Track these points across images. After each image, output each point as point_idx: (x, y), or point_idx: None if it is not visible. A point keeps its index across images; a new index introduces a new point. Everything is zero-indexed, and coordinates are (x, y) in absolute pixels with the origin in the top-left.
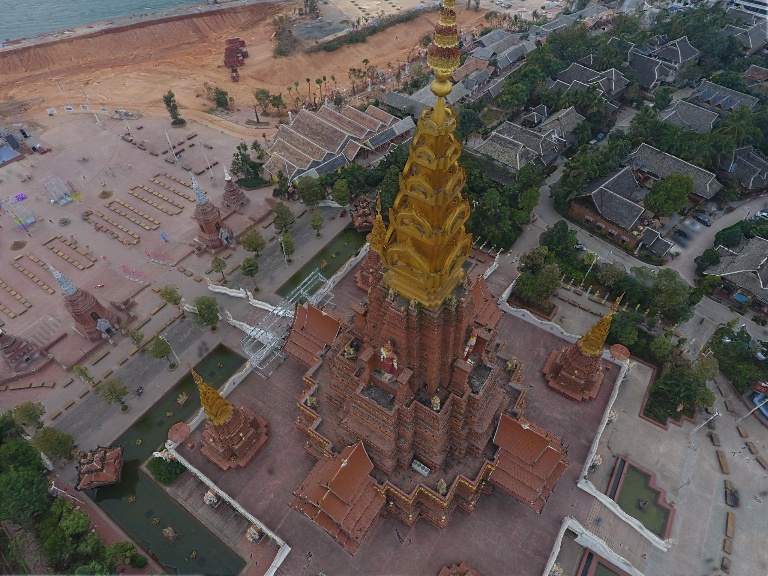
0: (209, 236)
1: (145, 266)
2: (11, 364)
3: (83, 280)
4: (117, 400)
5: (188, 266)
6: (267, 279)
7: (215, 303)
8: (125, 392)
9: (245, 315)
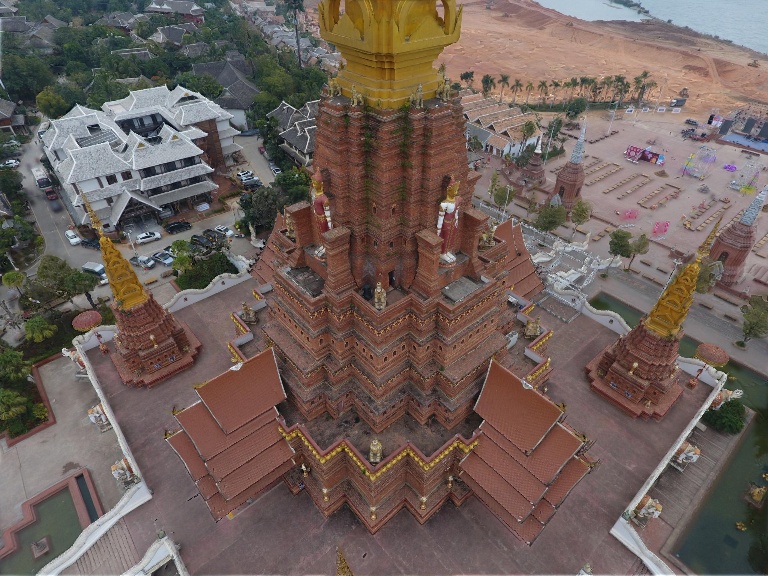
0: (705, 257)
1: (652, 234)
2: (520, 174)
3: (624, 205)
4: None
5: (650, 249)
6: (626, 286)
7: (557, 219)
8: None
9: (562, 266)
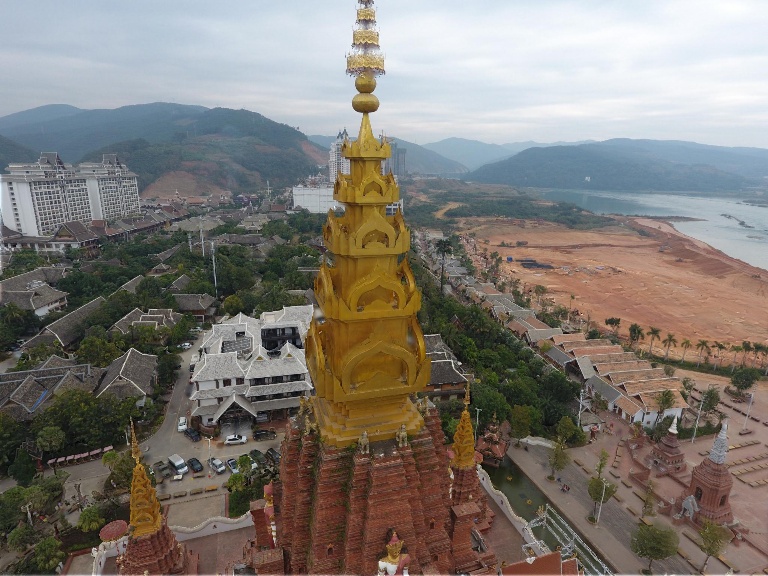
0: None
1: None
2: (650, 452)
3: None
4: (551, 461)
5: None
6: None
7: (663, 547)
8: (559, 468)
9: None
